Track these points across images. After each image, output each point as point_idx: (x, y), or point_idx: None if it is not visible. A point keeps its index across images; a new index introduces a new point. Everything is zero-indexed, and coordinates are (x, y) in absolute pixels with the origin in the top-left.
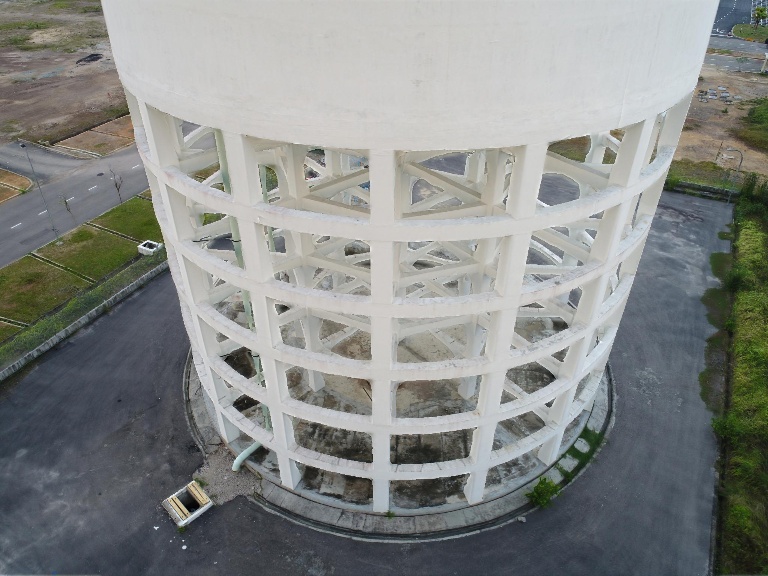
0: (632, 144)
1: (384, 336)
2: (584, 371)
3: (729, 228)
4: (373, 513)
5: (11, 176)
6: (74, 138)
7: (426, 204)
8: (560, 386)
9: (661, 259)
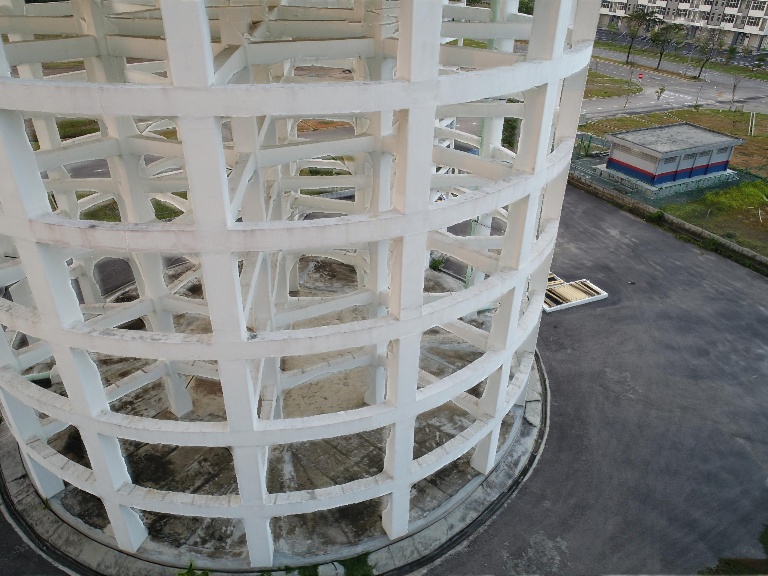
0: None
1: None
2: (262, 432)
3: None
4: (39, 493)
5: None
6: None
7: (314, 180)
8: (202, 430)
9: None
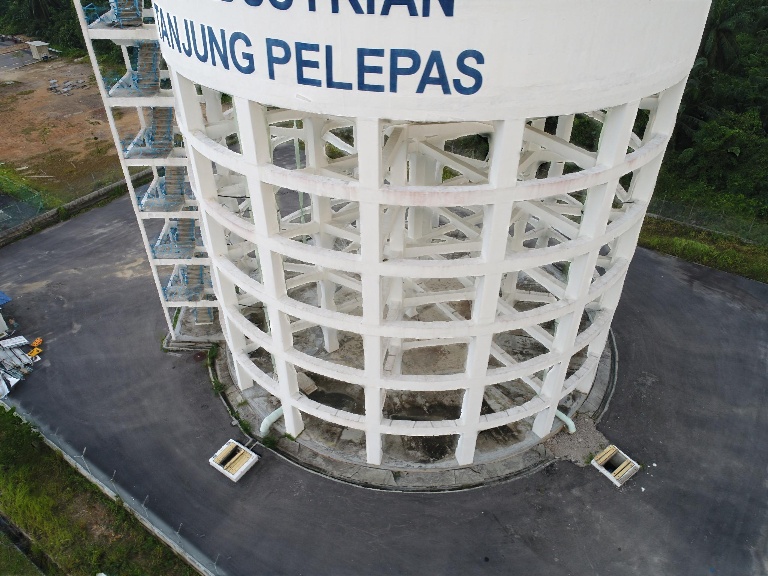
0: None
1: None
2: None
3: (292, 143)
4: None
5: None
6: None
7: None
8: None
9: None
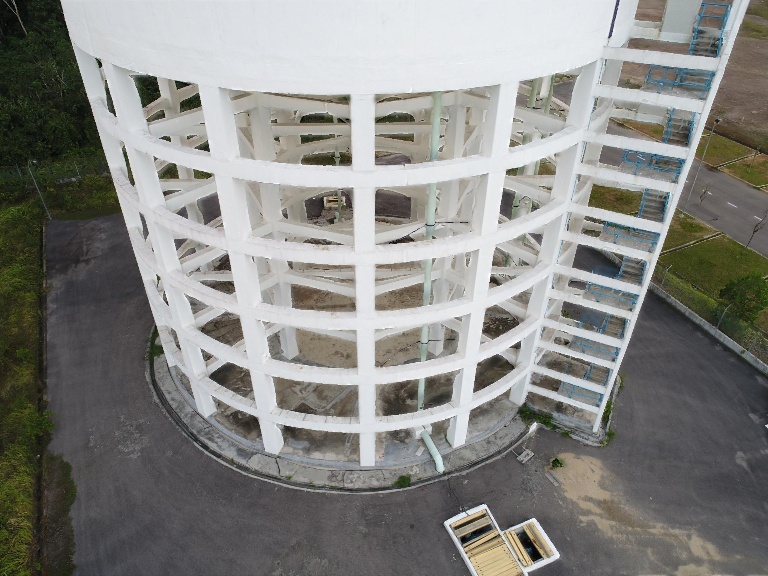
0: None
1: None
2: None
3: None
4: None
5: None
6: None
7: None
8: None
9: None
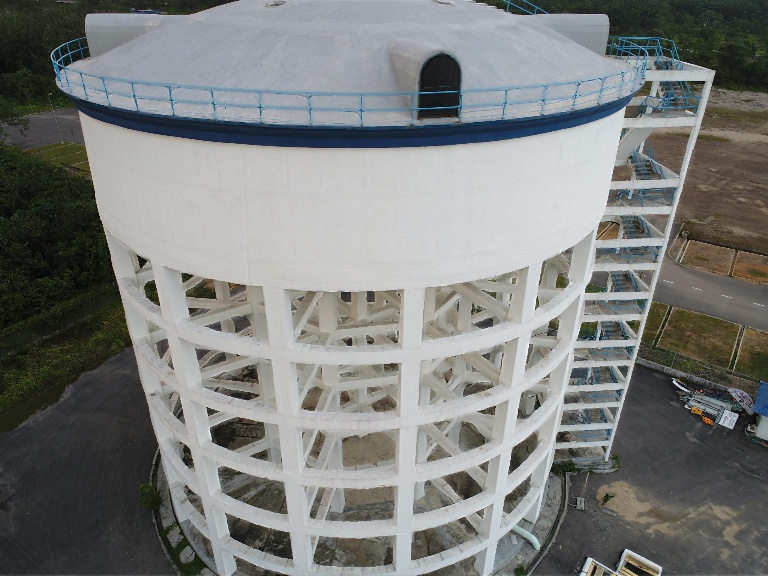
0: None
1: None
2: None
3: None
4: None
5: (616, 234)
6: (711, 246)
7: None
8: None
9: None
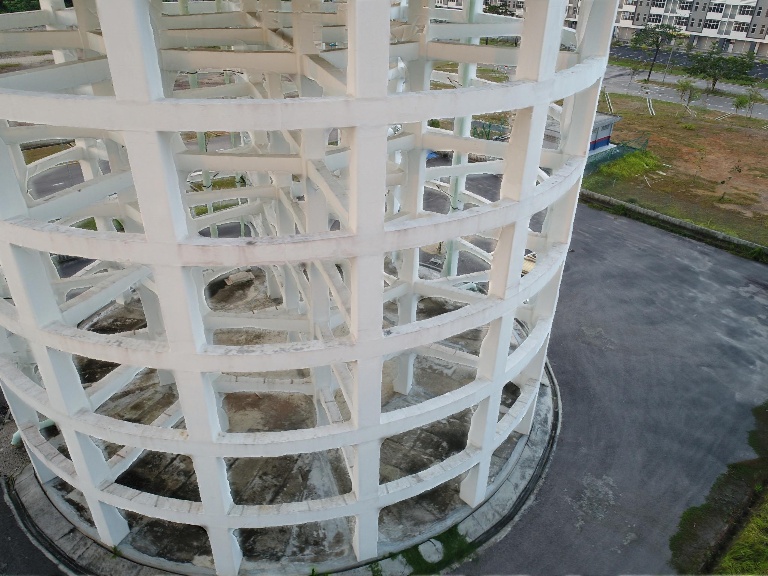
0: (351, 15)
1: (13, 272)
2: (387, 424)
3: None
4: (101, 543)
5: None
6: None
7: None
8: (331, 433)
9: (721, 346)
